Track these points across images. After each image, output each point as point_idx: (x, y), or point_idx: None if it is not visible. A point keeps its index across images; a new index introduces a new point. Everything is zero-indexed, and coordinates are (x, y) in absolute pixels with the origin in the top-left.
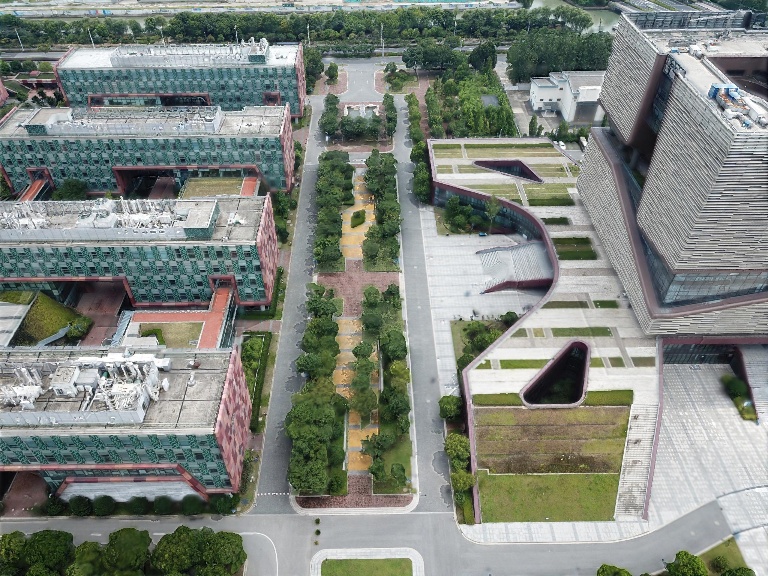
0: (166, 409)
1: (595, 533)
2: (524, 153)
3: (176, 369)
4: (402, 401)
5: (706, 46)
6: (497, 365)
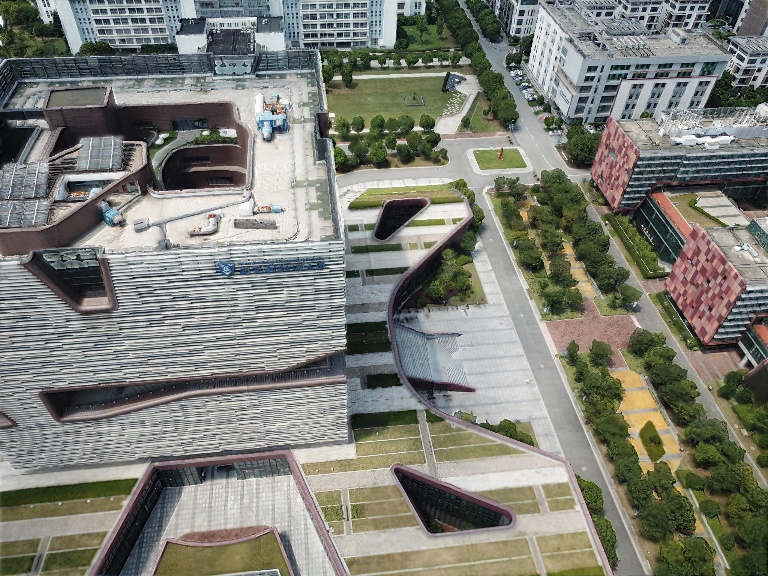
0: (649, 127)
1: (380, 184)
2: (422, 565)
3: (665, 143)
4: (512, 211)
5: (218, 224)
6: (447, 221)
